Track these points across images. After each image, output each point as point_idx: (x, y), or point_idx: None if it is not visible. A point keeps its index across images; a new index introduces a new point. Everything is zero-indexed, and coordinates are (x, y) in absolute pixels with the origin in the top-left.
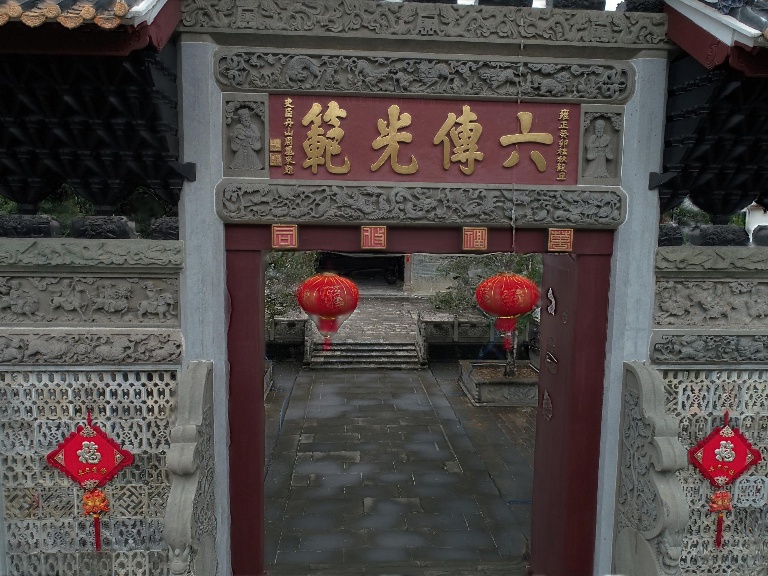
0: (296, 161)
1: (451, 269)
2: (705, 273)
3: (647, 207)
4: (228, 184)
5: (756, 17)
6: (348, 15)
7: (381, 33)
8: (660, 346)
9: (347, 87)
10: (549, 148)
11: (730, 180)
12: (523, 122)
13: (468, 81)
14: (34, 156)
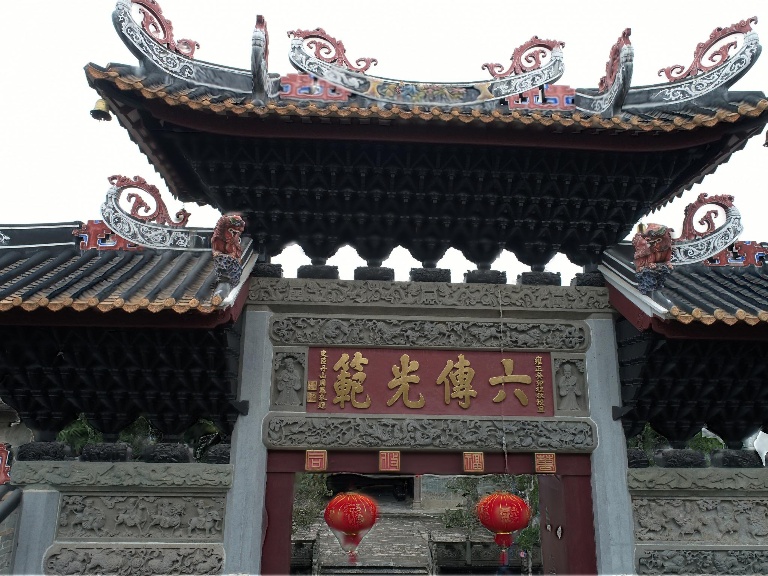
0: (328, 398)
1: (460, 486)
2: (672, 492)
3: (614, 435)
4: (273, 417)
5: (664, 299)
6: (370, 291)
7: (395, 303)
8: (644, 561)
9: (369, 342)
10: (529, 387)
11: (677, 412)
12: (506, 367)
13: (461, 336)
14: (126, 397)
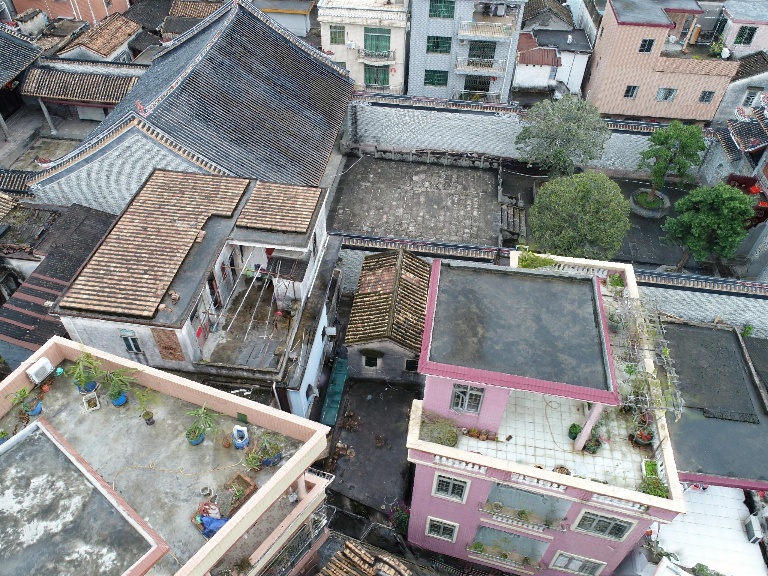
0: None
1: None
2: None
3: None
4: None
5: None
6: None
7: None
8: None
9: None
10: None
11: None
12: None
13: None
14: None
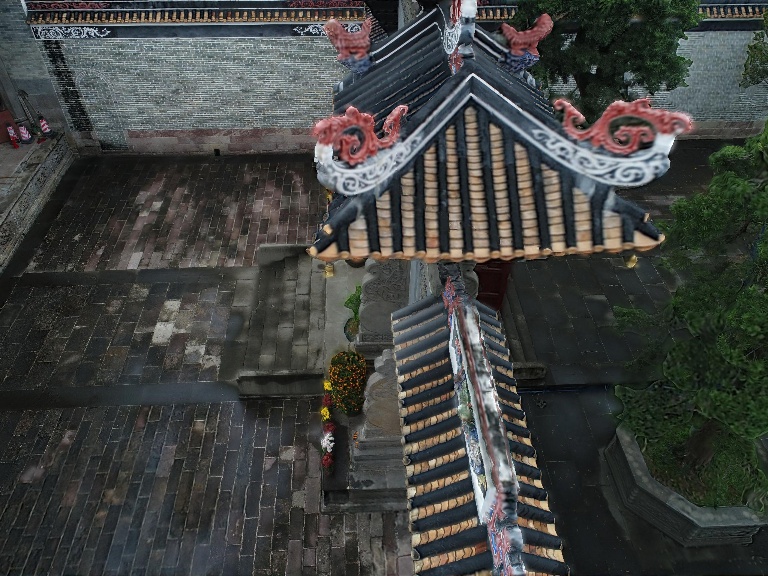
0: None
1: None
2: None
3: None
4: None
5: None
6: None
7: None
8: None
9: None
10: None
11: None
12: None
13: None
14: None
